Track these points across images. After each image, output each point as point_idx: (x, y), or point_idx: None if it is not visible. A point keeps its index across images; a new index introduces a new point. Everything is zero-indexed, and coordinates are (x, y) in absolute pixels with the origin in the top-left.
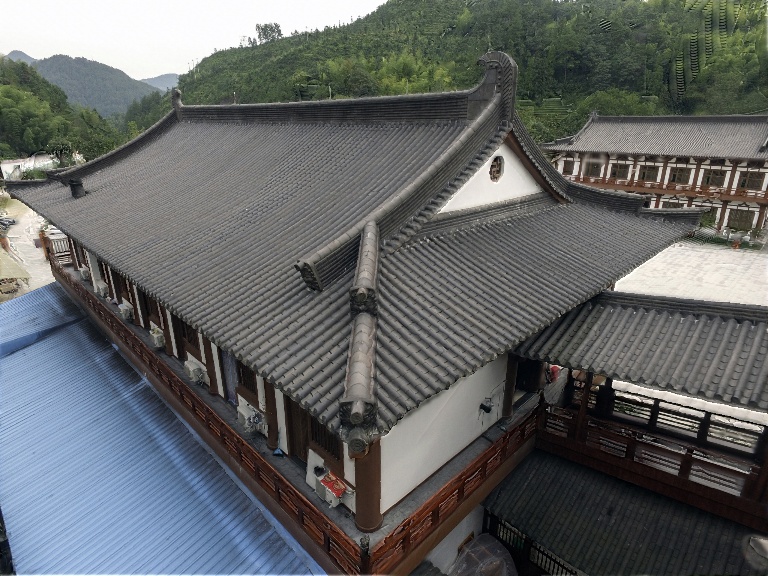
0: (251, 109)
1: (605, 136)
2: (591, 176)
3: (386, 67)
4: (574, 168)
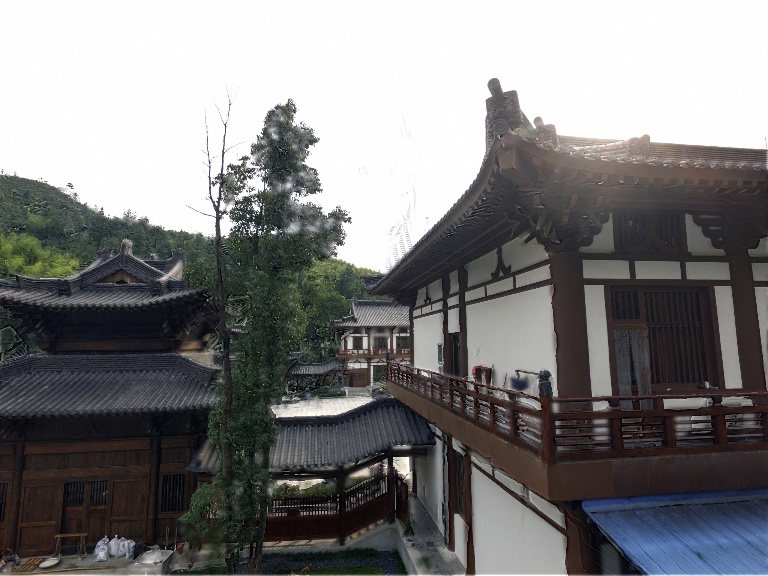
0: (725, 151)
1: (376, 315)
2: (380, 349)
3: (12, 245)
4: (363, 343)
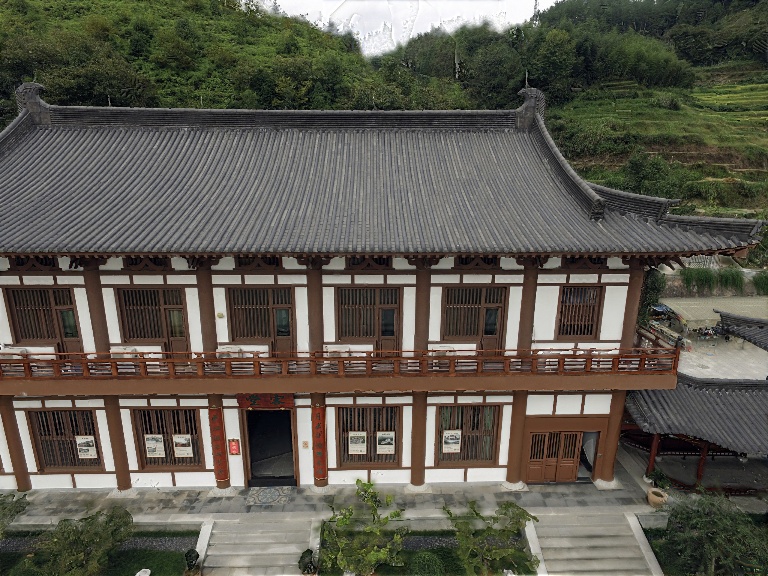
0: None
1: None
2: None
3: None
4: None
